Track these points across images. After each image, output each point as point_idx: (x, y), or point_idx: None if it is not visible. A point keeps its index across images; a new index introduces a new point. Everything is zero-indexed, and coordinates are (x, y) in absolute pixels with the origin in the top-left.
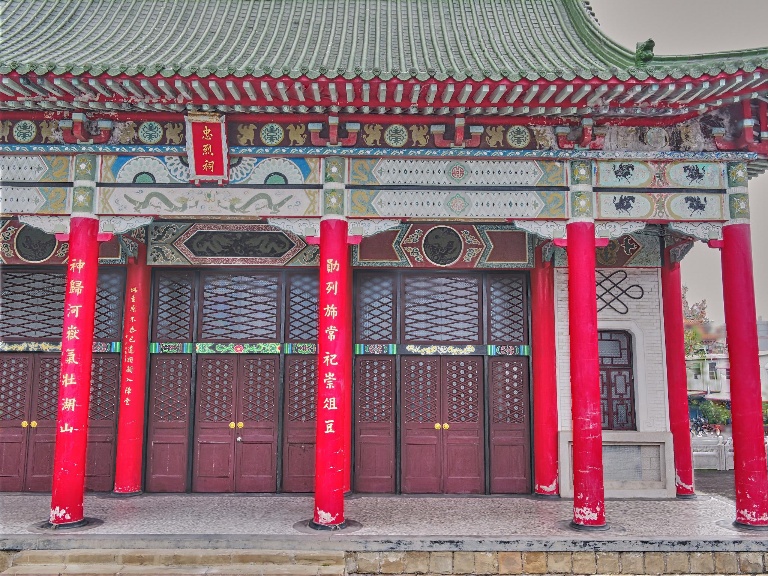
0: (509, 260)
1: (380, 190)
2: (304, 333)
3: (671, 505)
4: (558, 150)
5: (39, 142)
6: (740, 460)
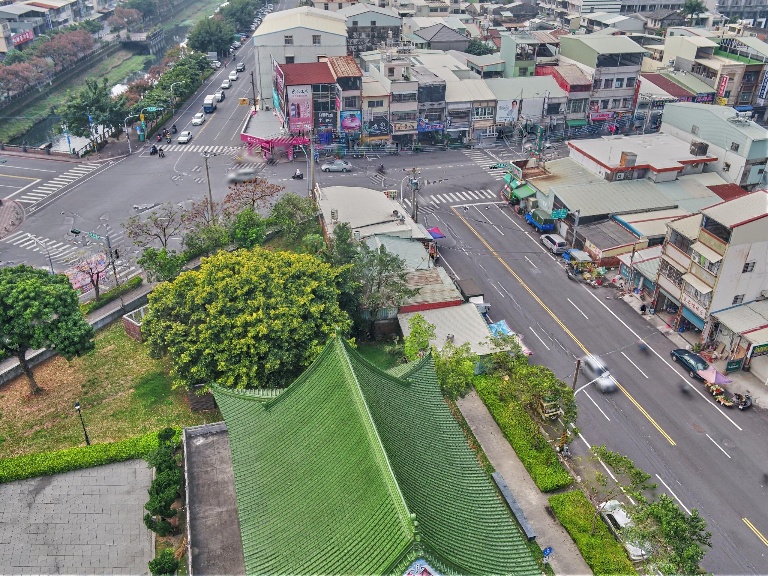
0: None
1: None
2: None
3: None
4: None
5: None
6: None
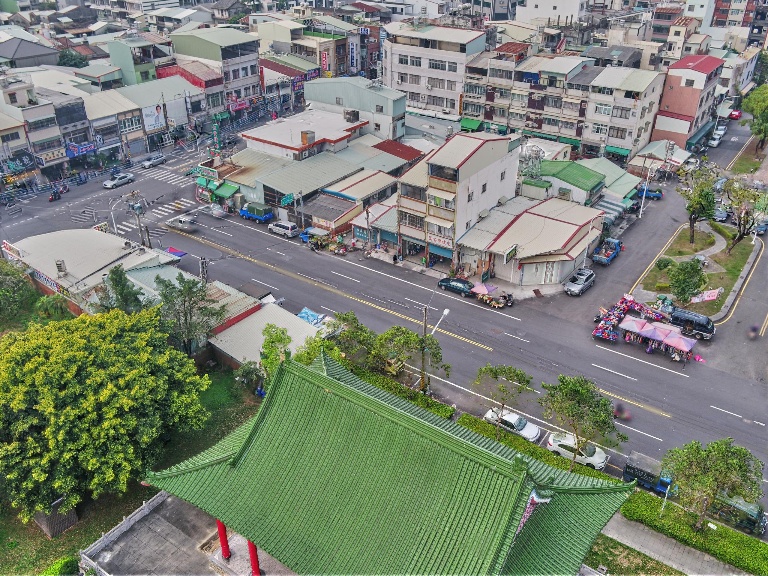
0: None
1: None
2: None
3: None
4: None
5: None
6: None
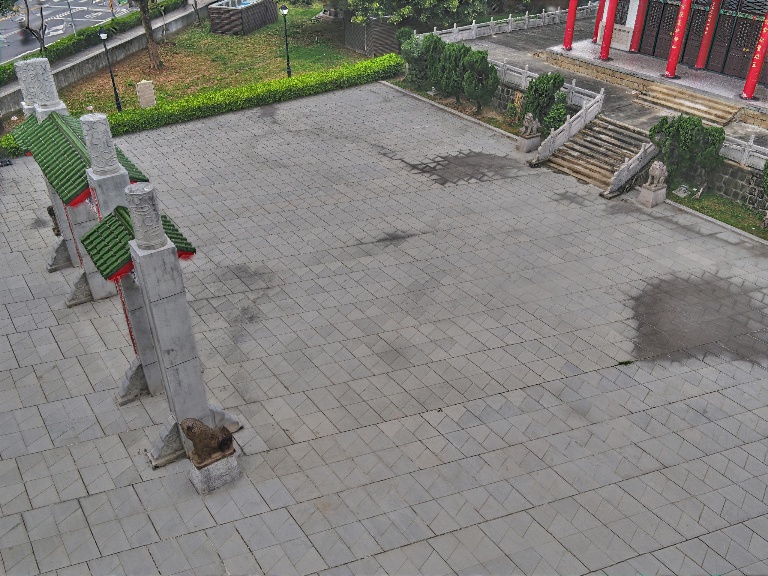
0: None
1: None
2: None
3: None
4: None
5: None
6: None
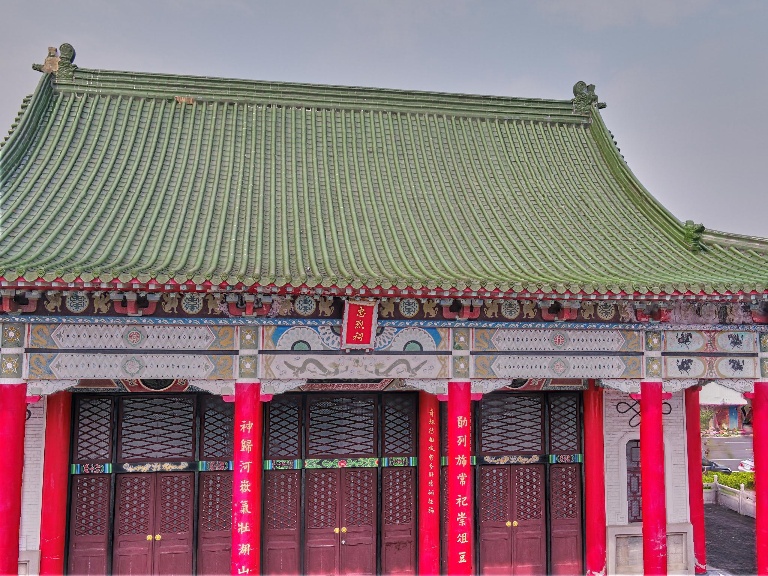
0: (568, 383)
1: (498, 356)
2: (397, 447)
3: None
4: (638, 323)
5: (206, 313)
6: (764, 566)
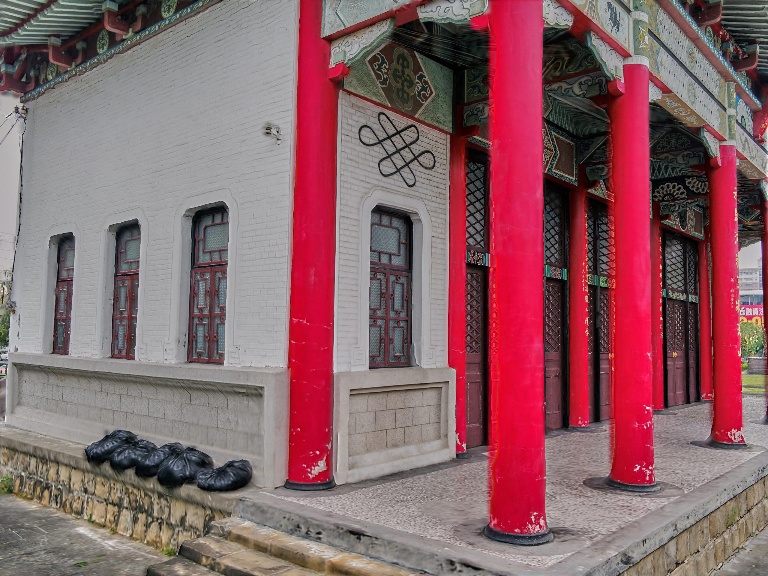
0: None
1: None
2: None
3: (757, 399)
4: None
5: None
6: None
